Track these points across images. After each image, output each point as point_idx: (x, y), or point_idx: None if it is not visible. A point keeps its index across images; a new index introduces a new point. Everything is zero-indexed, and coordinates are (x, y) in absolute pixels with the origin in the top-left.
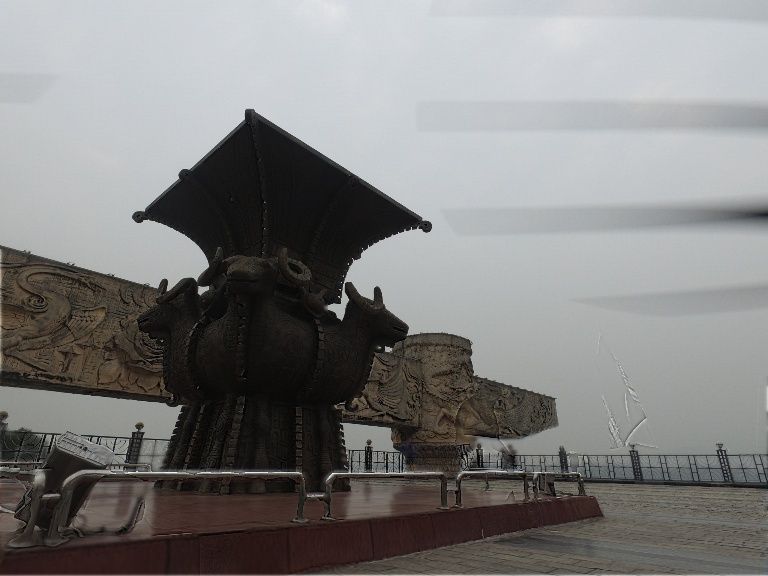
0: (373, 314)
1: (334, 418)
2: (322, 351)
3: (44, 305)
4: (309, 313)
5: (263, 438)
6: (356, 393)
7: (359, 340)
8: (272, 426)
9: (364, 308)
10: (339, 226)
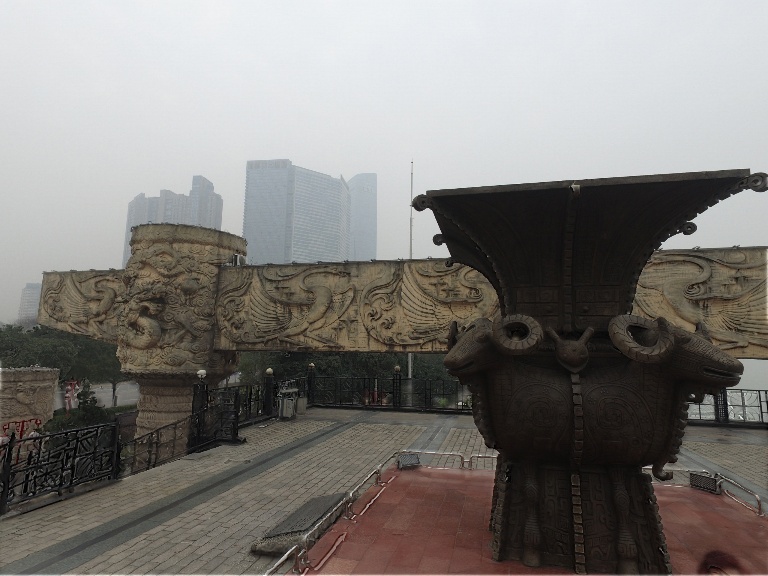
0: (651, 362)
1: (639, 484)
2: (580, 418)
3: (480, 295)
4: (564, 368)
5: (532, 508)
6: (664, 457)
7: (649, 390)
8: (546, 493)
9: (632, 357)
10: (598, 237)
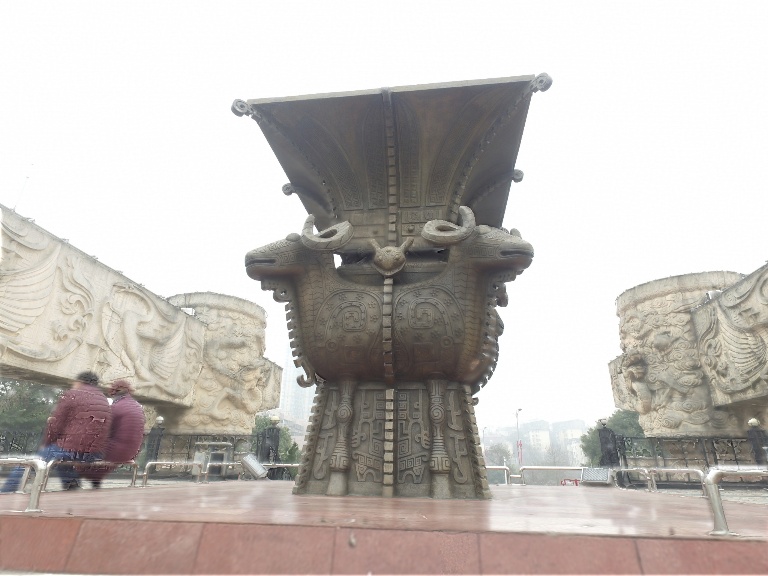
0: None
1: None
2: None
3: None
4: None
5: None
6: None
7: None
8: None
9: None
10: None
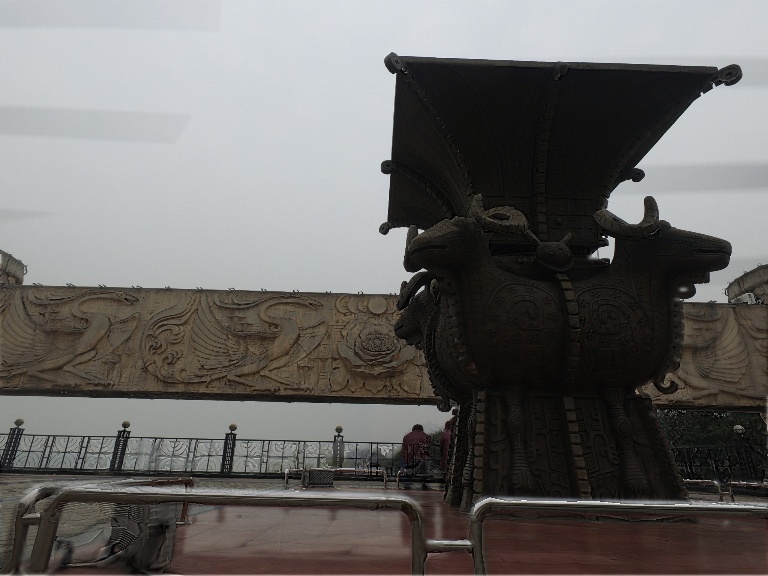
0: None
1: None
2: None
3: None
4: None
5: None
6: None
7: None
8: None
9: None
10: None
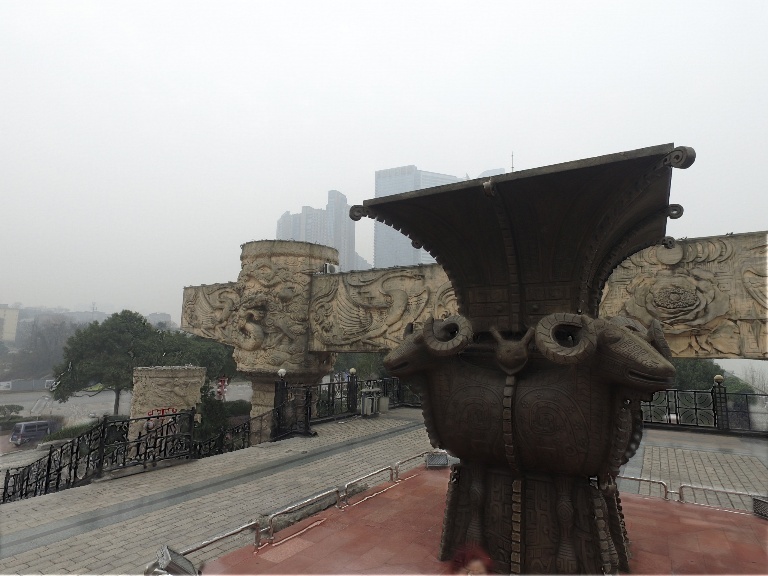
0: (570, 363)
1: (586, 497)
2: (508, 421)
3: None
4: None
5: (476, 511)
6: (605, 469)
7: (583, 395)
8: (492, 498)
9: (550, 358)
10: (539, 232)
